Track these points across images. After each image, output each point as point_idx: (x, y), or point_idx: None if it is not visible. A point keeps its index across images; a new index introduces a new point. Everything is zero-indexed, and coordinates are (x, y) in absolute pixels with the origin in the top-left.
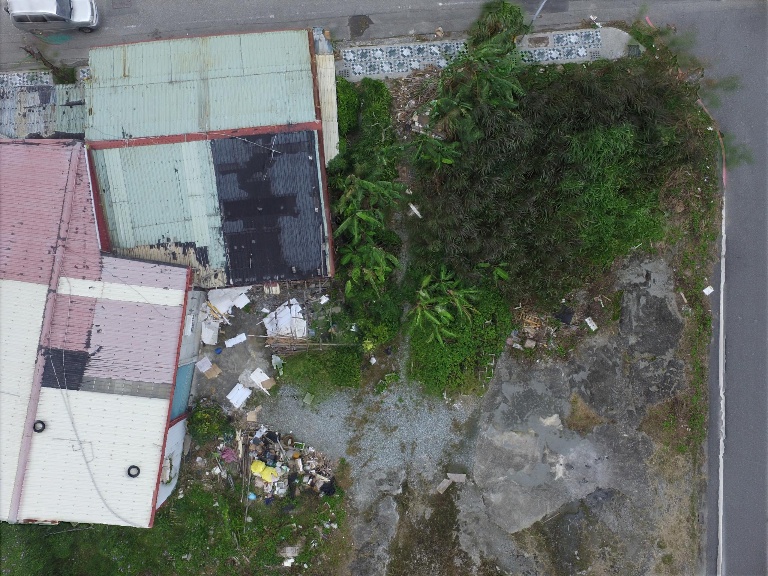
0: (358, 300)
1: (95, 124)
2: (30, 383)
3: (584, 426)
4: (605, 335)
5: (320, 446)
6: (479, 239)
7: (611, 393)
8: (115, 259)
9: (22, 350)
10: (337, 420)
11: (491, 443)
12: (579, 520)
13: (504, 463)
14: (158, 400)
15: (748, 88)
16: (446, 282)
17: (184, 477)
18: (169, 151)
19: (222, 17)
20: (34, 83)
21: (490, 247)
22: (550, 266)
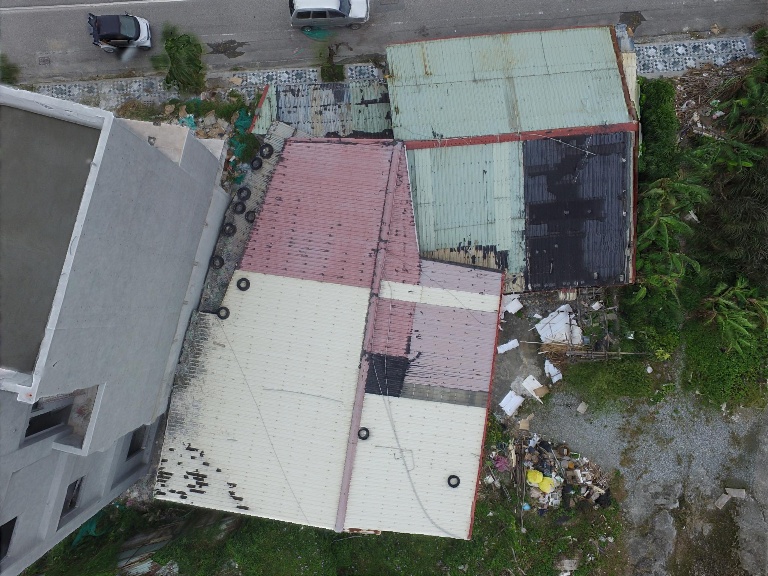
0: (645, 307)
1: (403, 123)
2: (354, 389)
3: None
4: None
5: (594, 457)
6: None
7: None
8: (433, 263)
9: (345, 355)
10: (611, 430)
11: None
12: None
13: None
14: (475, 408)
15: None
16: (741, 290)
17: None
18: (480, 152)
19: (490, 13)
20: (303, 81)
21: None
22: None
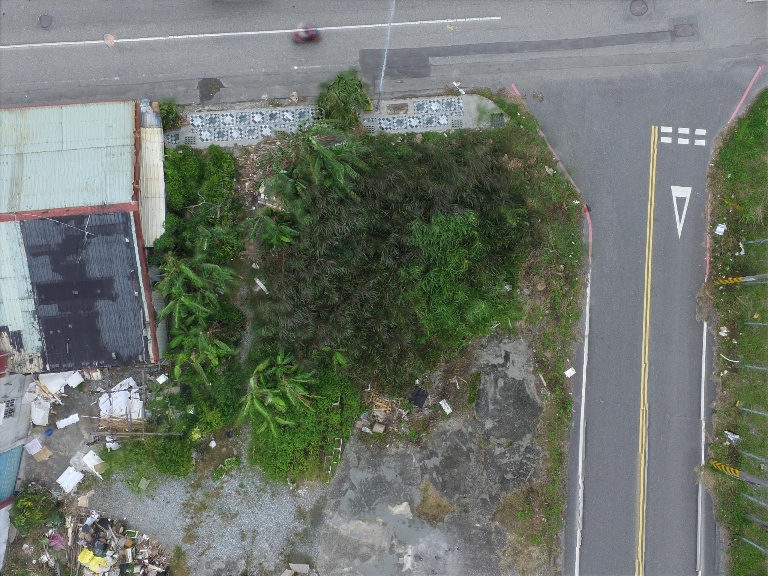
0: (192, 383)
1: None
2: None
3: (435, 515)
4: (460, 419)
5: (155, 534)
6: (315, 323)
7: (464, 480)
8: None
9: None
10: (174, 506)
11: (336, 532)
12: None
13: (349, 553)
14: None
15: (617, 160)
16: (284, 366)
17: (8, 566)
18: None
19: (64, 78)
20: None
21: (322, 334)
22: (390, 353)
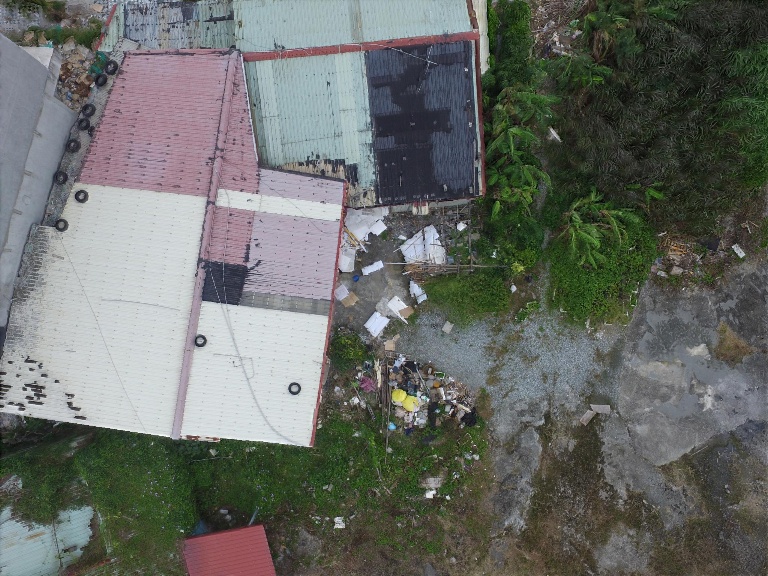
0: (503, 223)
1: (245, 36)
2: (191, 297)
3: (733, 356)
4: (753, 262)
5: (460, 376)
6: None
7: (760, 322)
8: (272, 172)
9: (182, 263)
10: (477, 350)
11: (636, 373)
12: (729, 453)
13: (650, 394)
14: (317, 316)
15: None
16: (595, 204)
17: (322, 407)
18: (322, 63)
19: None
20: None
21: (649, 163)
22: (707, 185)
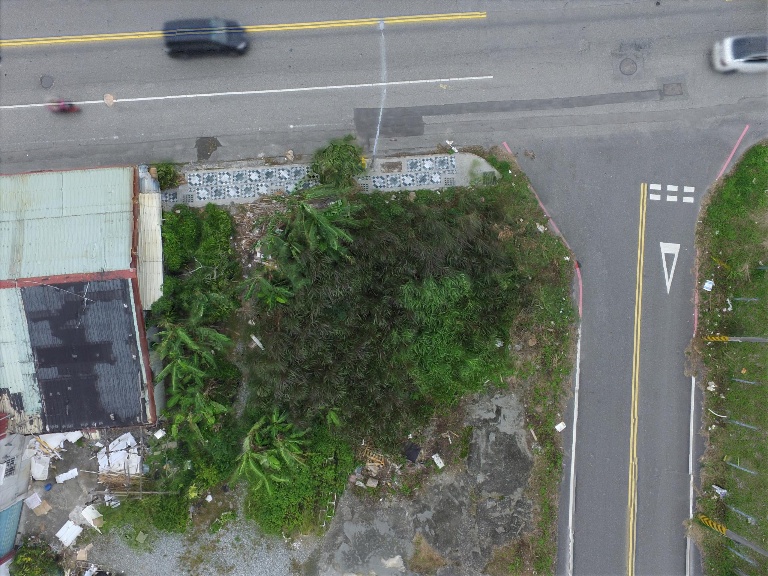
0: (189, 440)
1: None
2: None
3: (427, 568)
4: (452, 473)
5: None
6: (309, 384)
7: (456, 534)
8: None
9: None
10: (171, 559)
11: None
12: None
13: None
14: None
15: (607, 217)
16: (279, 424)
17: None
18: None
19: (64, 138)
20: None
21: (316, 396)
22: (383, 412)
